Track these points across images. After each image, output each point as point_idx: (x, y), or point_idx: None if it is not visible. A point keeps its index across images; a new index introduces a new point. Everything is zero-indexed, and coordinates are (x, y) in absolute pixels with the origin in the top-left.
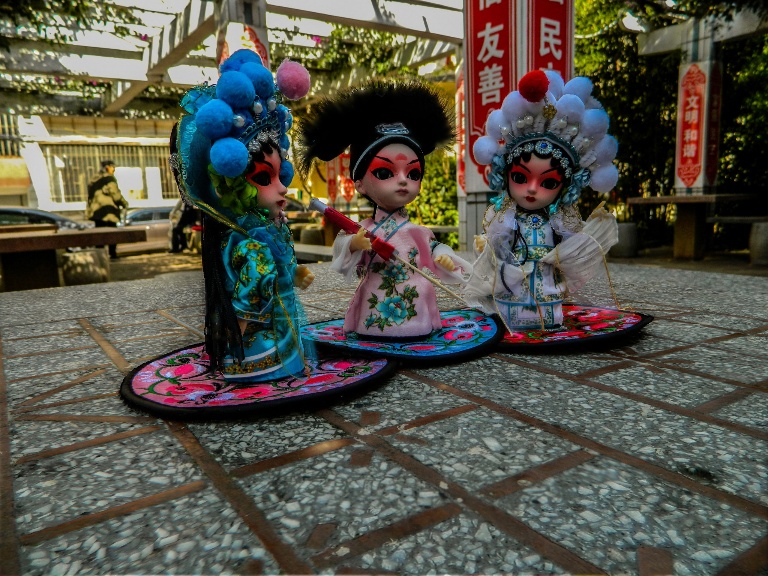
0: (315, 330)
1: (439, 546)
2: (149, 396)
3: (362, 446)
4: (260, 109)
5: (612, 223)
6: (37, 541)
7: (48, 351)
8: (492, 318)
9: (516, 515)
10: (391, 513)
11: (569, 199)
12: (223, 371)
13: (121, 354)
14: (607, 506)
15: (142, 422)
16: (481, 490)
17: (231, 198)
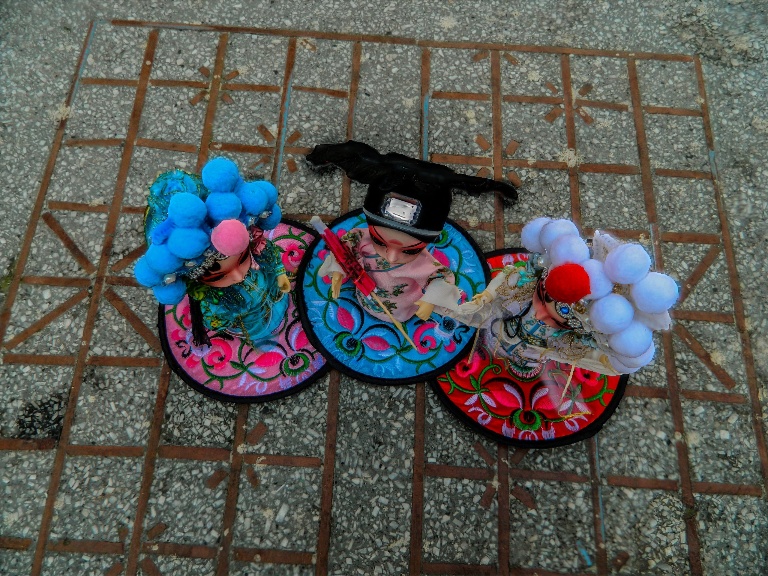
0: None
1: (186, 572)
2: (168, 321)
3: (226, 466)
4: (193, 264)
5: None
6: (72, 454)
7: (165, 142)
8: (475, 331)
9: None
10: (190, 536)
11: None
12: None
13: None
14: None
15: (154, 349)
16: (236, 549)
17: None
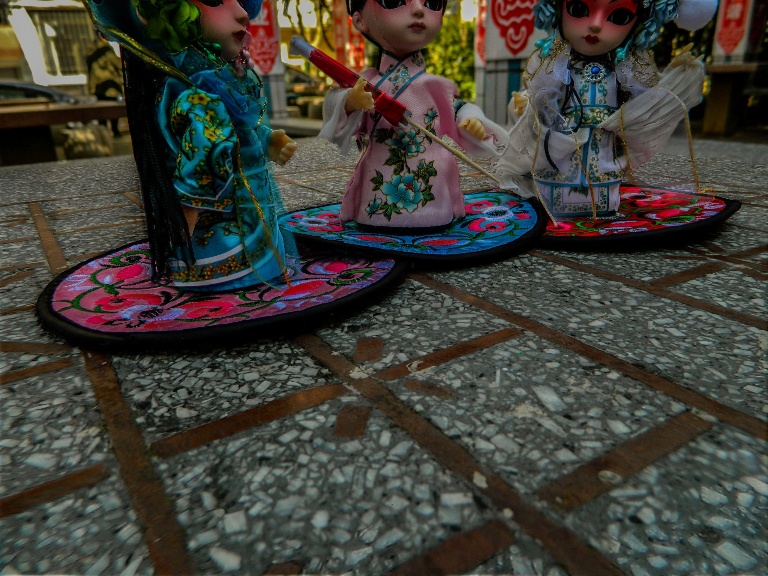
0: (305, 218)
1: None
2: (68, 313)
3: (354, 399)
4: None
5: (698, 74)
6: None
7: None
8: (530, 203)
9: (607, 550)
10: (394, 541)
11: (644, 39)
12: (172, 277)
13: (61, 249)
14: (759, 532)
15: (51, 353)
16: (541, 492)
17: (161, 24)
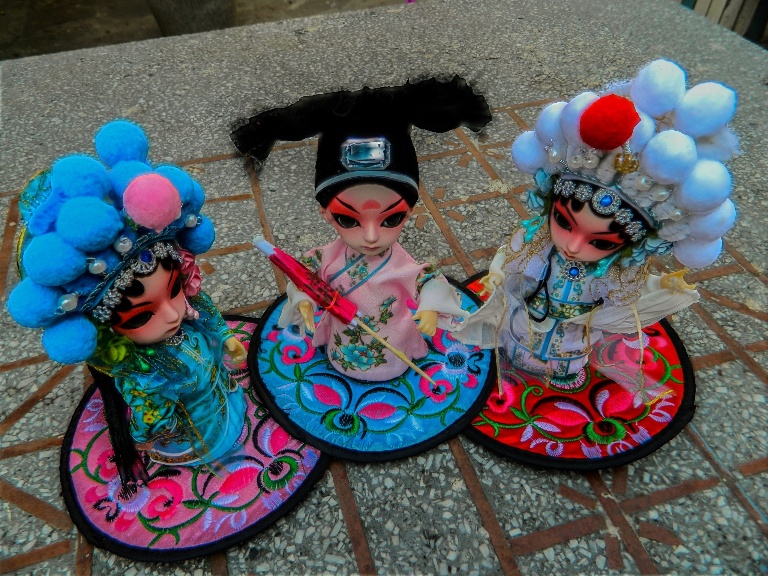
0: None
1: None
2: (76, 480)
3: None
4: (102, 268)
5: None
6: None
7: None
8: (491, 355)
9: None
10: None
11: (630, 263)
12: None
13: None
14: None
15: (60, 528)
16: None
17: None
